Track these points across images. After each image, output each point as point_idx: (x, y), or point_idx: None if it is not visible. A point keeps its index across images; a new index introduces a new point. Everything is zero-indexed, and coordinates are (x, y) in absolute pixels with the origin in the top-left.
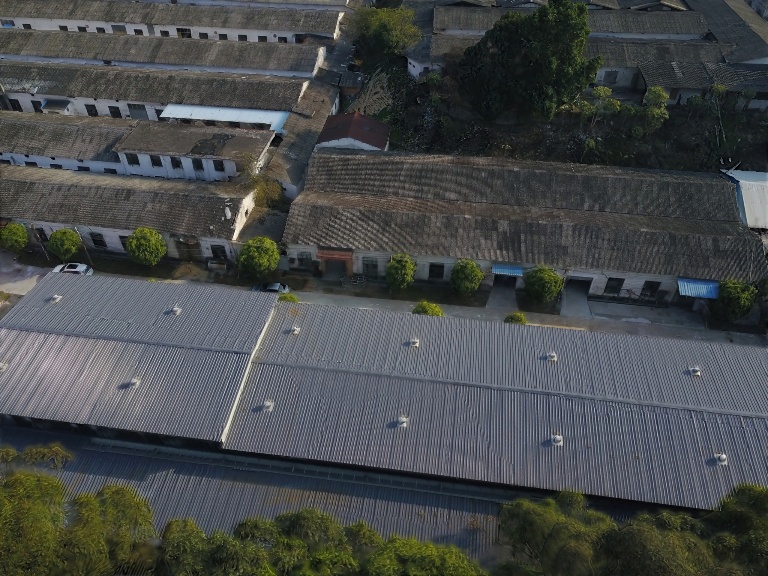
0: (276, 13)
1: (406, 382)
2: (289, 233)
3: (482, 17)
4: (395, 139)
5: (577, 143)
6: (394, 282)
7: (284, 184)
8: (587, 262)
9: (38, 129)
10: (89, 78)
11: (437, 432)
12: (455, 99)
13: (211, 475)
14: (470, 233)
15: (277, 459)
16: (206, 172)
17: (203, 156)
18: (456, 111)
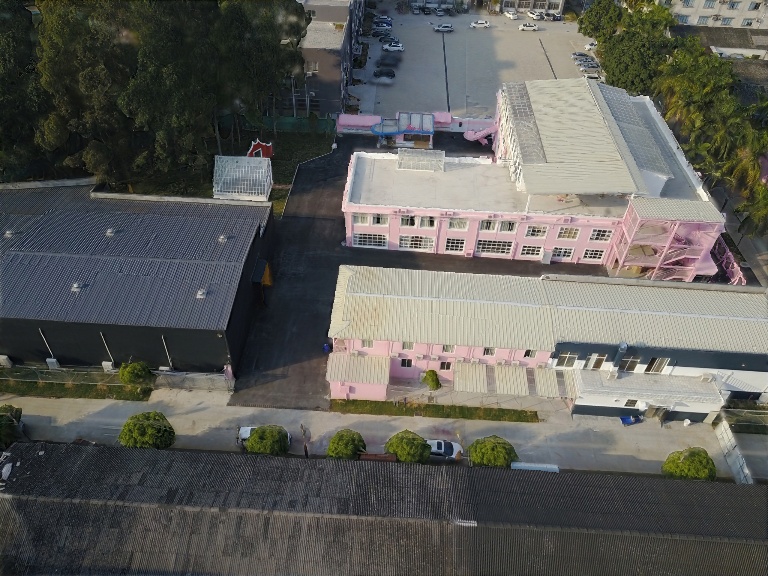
0: None
1: None
2: None
3: None
4: None
5: None
6: None
7: None
8: None
9: None
10: None
11: None
12: None
13: None
14: None
15: None
16: None
17: None
18: None
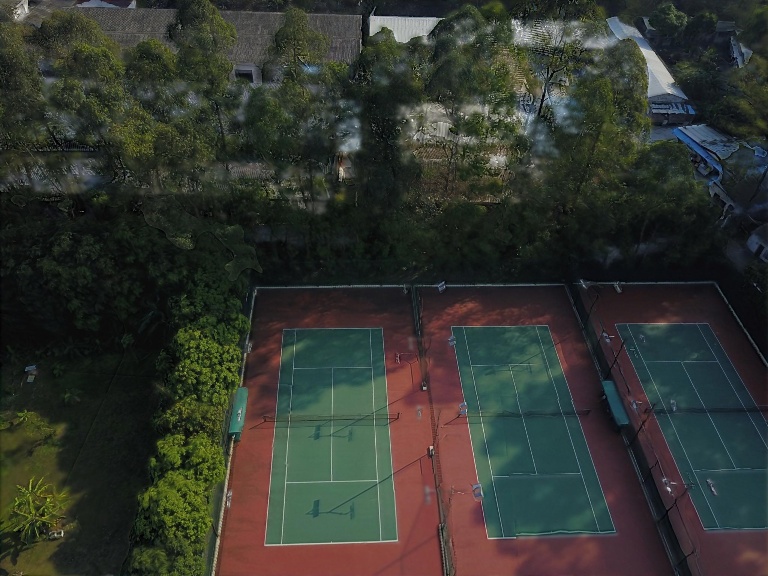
0: None
1: None
2: None
3: None
4: (142, 7)
5: (274, 3)
6: None
7: None
8: (244, 58)
9: None
10: None
11: None
12: None
13: None
14: (167, 44)
15: None
16: None
17: None
18: None
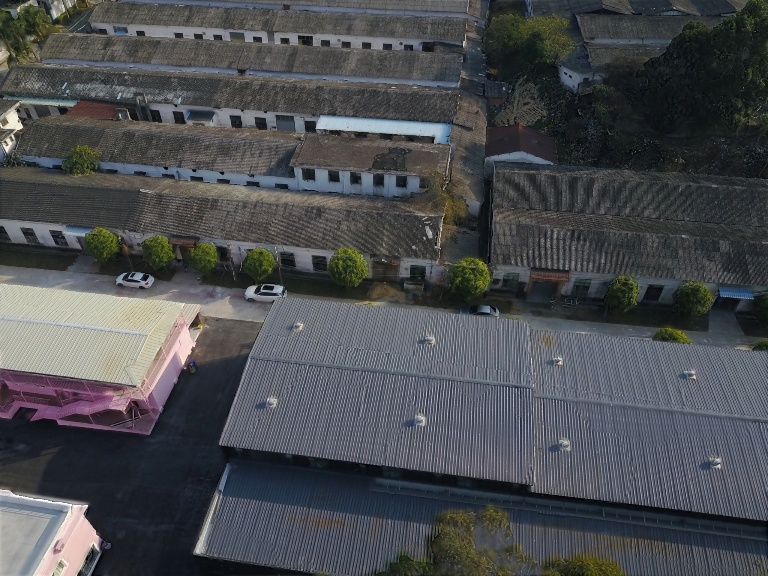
0: (401, 20)
1: (702, 419)
2: (498, 254)
3: (631, 25)
4: None
5: (754, 157)
6: (618, 306)
7: (468, 200)
8: None
9: (203, 142)
10: (233, 88)
11: (756, 474)
12: (625, 111)
13: (517, 520)
14: (691, 254)
15: (586, 503)
16: (386, 188)
17: (387, 172)
18: (623, 123)
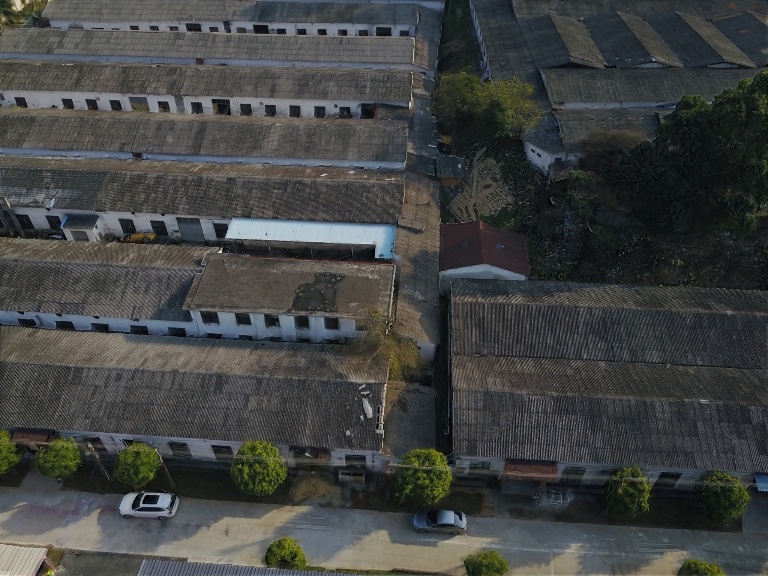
0: (334, 77)
1: None
2: (461, 439)
3: (606, 85)
4: None
5: (767, 255)
6: (626, 512)
7: (419, 342)
8: None
9: (71, 274)
10: (122, 184)
11: None
12: (608, 203)
13: None
14: (715, 429)
15: None
16: (312, 330)
17: (311, 314)
18: (606, 216)
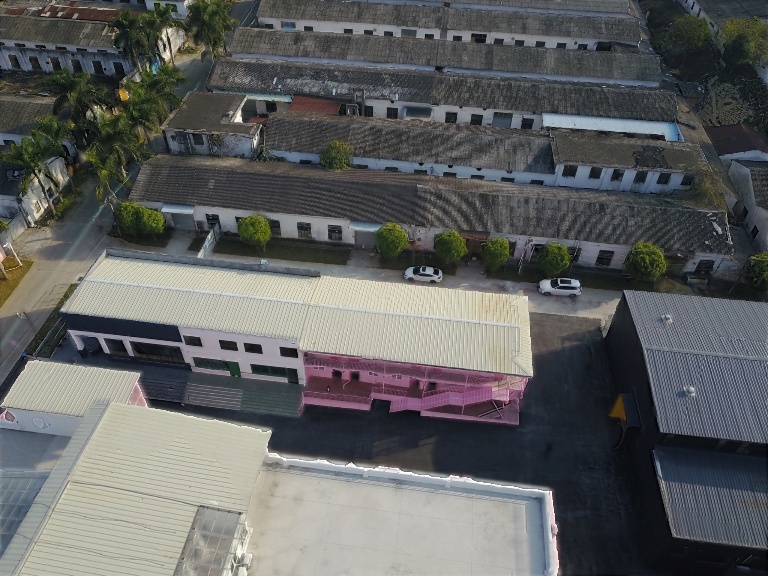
0: (574, 20)
1: None
2: None
3: None
4: None
5: None
6: None
7: (726, 197)
8: None
9: (453, 139)
10: (449, 85)
11: None
12: None
13: None
14: None
15: None
16: (646, 185)
17: (653, 169)
18: None
